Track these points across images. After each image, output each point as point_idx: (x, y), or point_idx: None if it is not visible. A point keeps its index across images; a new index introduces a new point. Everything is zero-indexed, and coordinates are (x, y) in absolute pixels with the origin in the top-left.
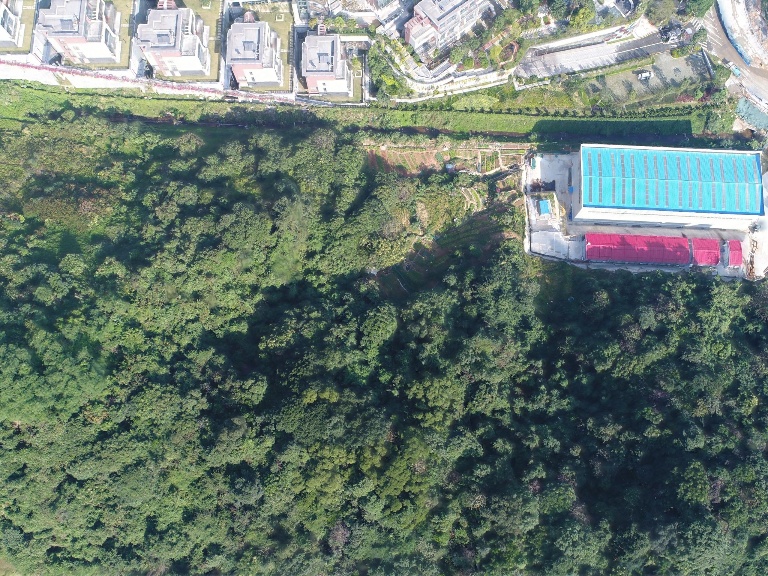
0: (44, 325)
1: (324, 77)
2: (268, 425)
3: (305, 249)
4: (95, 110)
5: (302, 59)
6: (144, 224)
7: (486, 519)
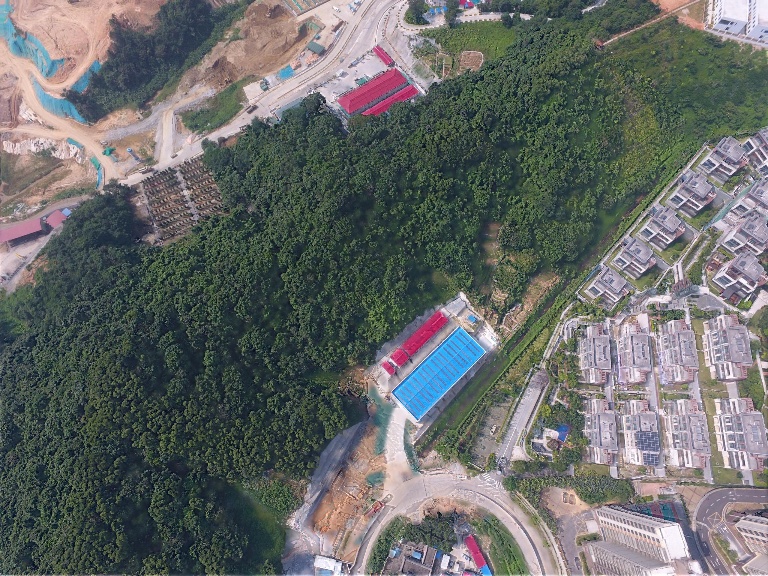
0: None
1: None
2: None
3: None
4: None
5: None
6: None
7: None
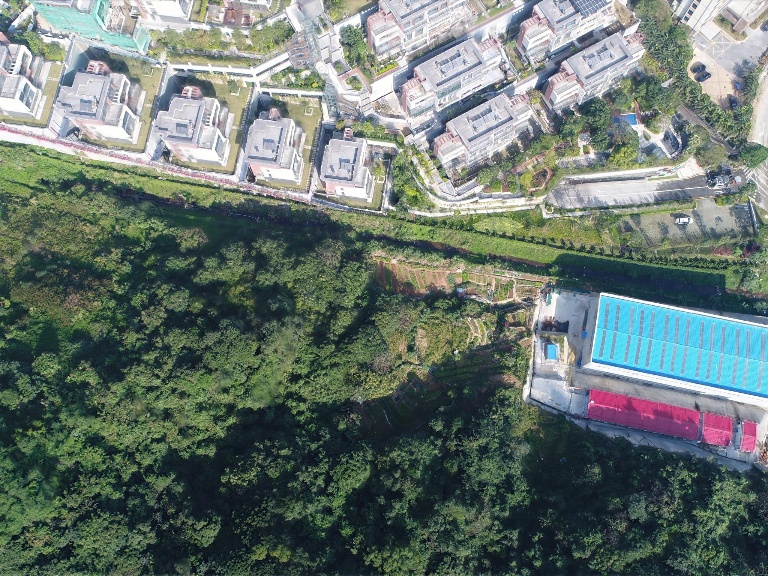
0: (3, 432)
1: (342, 184)
2: (212, 575)
3: (291, 370)
4: (107, 185)
5: (322, 163)
6: (128, 327)
7: None
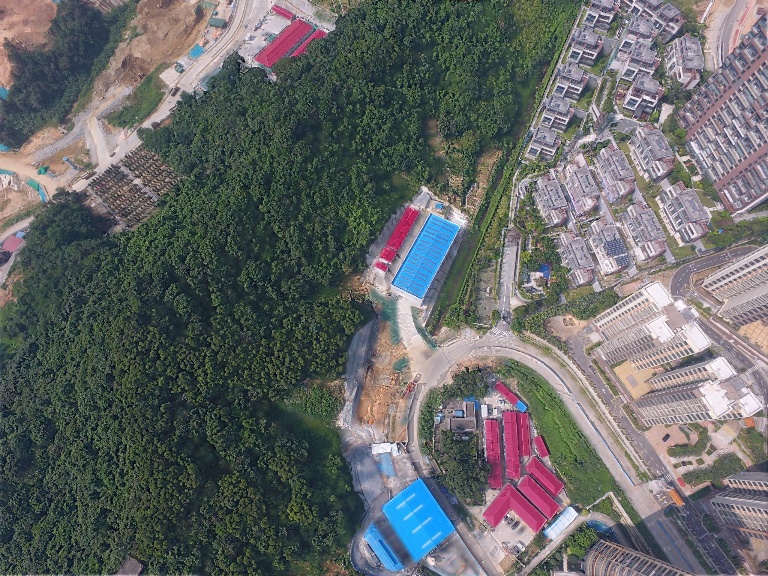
0: None
1: None
2: None
3: None
4: None
5: None
6: None
7: None
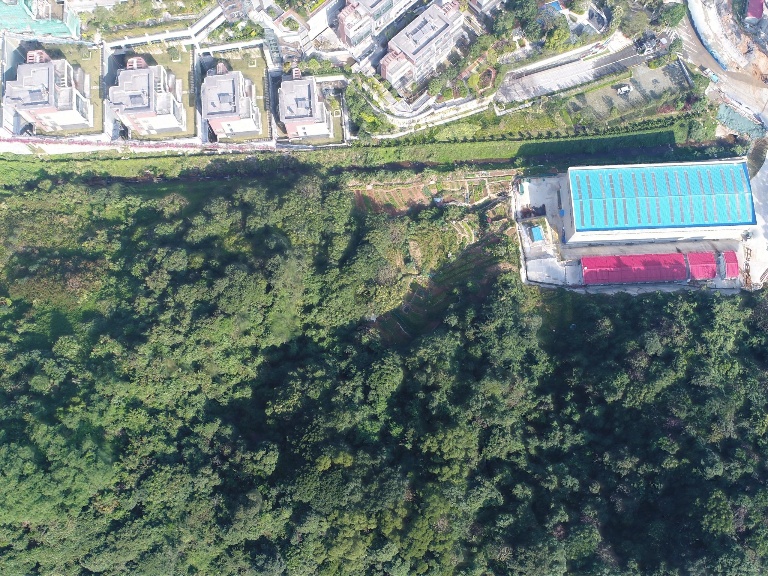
0: (44, 416)
1: (303, 122)
2: (284, 496)
3: (302, 303)
4: (72, 176)
5: (279, 106)
6: (135, 296)
7: (513, 570)
